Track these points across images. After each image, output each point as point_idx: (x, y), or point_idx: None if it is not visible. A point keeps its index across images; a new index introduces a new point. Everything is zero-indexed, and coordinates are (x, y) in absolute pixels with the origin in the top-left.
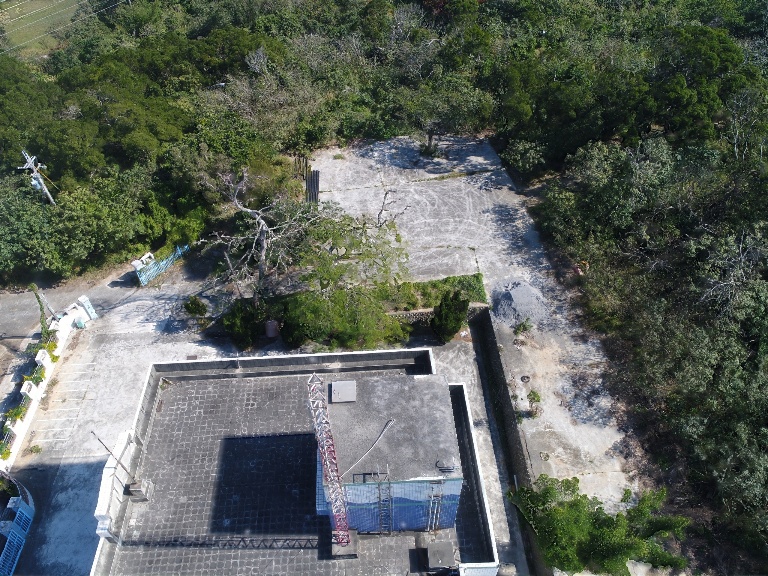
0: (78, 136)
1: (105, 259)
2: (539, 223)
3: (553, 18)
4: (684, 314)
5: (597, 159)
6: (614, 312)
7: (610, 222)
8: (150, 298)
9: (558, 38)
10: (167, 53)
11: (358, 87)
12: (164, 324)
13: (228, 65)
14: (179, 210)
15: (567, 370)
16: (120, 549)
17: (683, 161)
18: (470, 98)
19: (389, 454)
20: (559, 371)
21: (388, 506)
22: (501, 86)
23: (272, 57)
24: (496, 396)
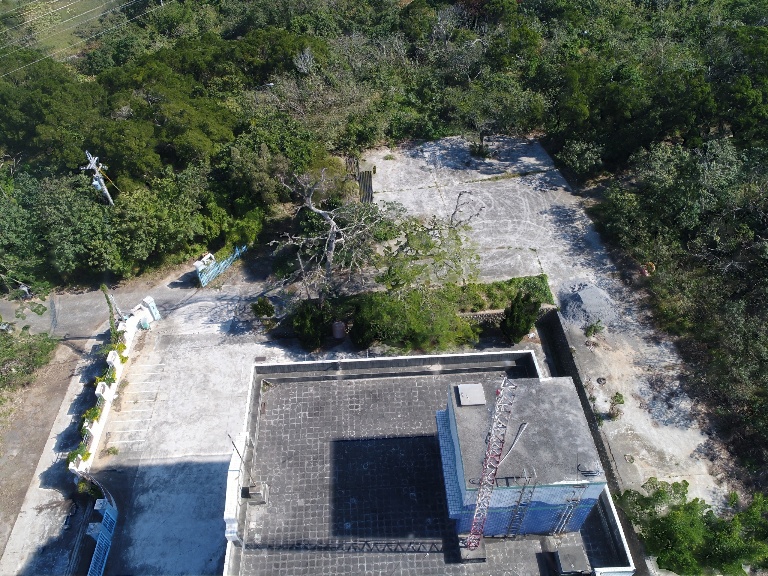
0: (135, 136)
1: (163, 260)
2: (599, 224)
3: (593, 18)
4: (762, 316)
5: (661, 160)
6: (685, 314)
7: (678, 223)
8: (212, 299)
9: (599, 38)
10: (208, 53)
11: (402, 87)
12: (229, 325)
13: (271, 65)
14: (236, 211)
15: (643, 372)
16: (244, 552)
17: (749, 162)
18: (521, 99)
19: (528, 458)
20: (635, 373)
21: (523, 510)
22: (552, 86)
23: (316, 57)
24: None
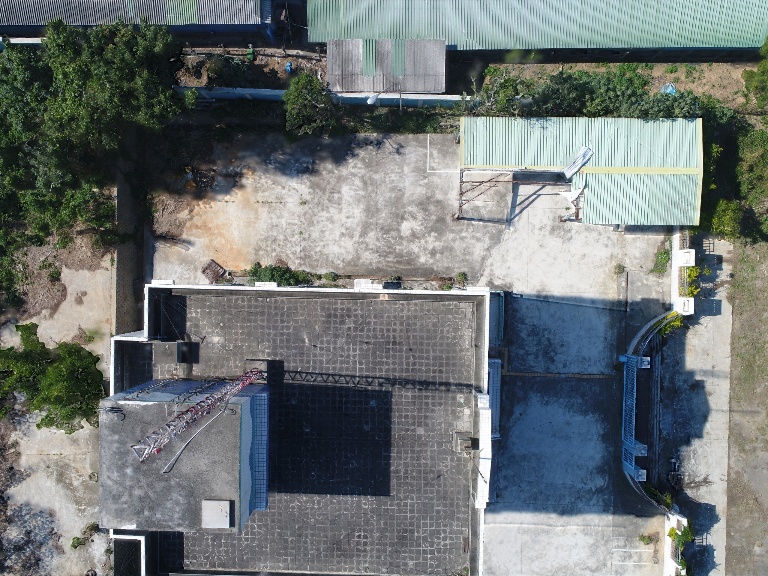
0: None
1: None
2: None
3: None
4: None
5: None
6: None
7: None
8: None
9: None
10: None
11: None
12: None
13: None
14: None
15: None
16: None
17: None
18: None
19: None
20: None
21: None
22: None
23: None
24: (133, 558)
